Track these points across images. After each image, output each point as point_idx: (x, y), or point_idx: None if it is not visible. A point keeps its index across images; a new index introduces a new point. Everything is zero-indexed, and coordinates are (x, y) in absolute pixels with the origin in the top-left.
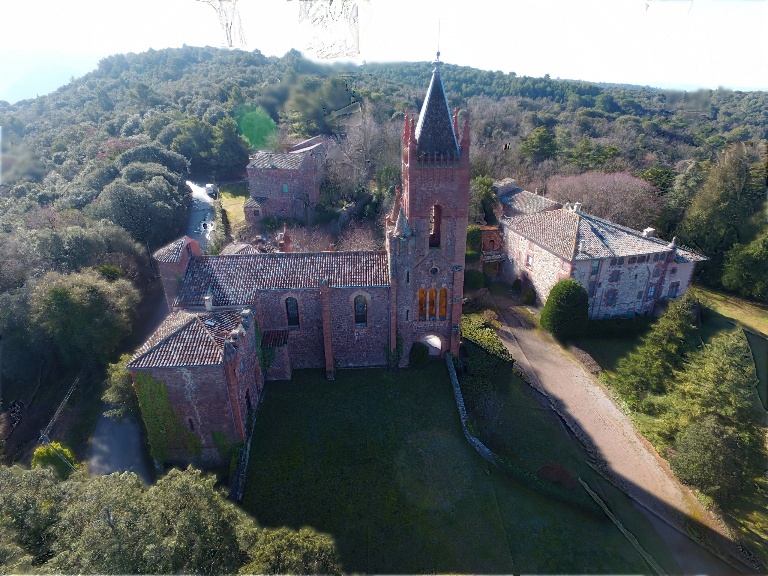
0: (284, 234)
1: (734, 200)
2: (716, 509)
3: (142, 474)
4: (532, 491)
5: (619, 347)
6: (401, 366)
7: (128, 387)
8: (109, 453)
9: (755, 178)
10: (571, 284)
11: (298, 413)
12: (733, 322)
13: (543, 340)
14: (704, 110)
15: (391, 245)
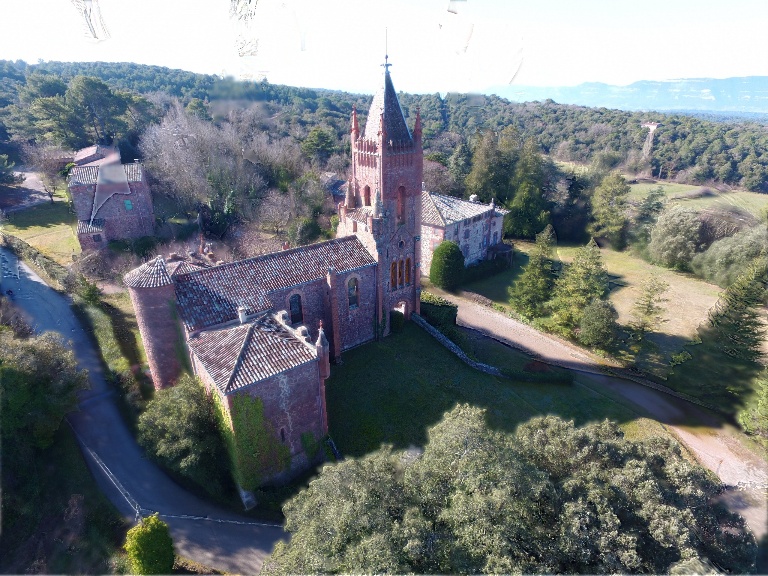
0: (202, 246)
1: (496, 171)
2: (609, 355)
3: (228, 516)
4: (530, 383)
5: (484, 285)
6: (385, 335)
7: (196, 426)
8: (166, 519)
9: (502, 154)
10: (451, 244)
11: (342, 397)
12: (525, 254)
13: (438, 294)
14: (482, 105)
15: (373, 226)
